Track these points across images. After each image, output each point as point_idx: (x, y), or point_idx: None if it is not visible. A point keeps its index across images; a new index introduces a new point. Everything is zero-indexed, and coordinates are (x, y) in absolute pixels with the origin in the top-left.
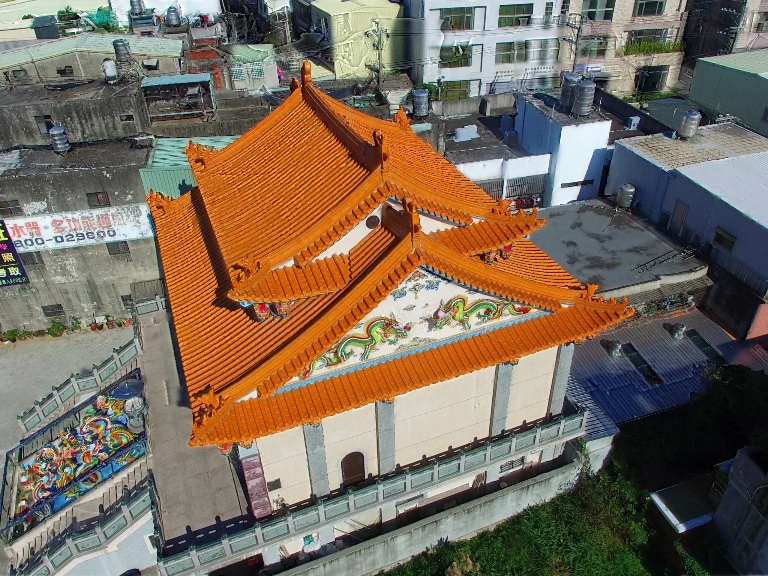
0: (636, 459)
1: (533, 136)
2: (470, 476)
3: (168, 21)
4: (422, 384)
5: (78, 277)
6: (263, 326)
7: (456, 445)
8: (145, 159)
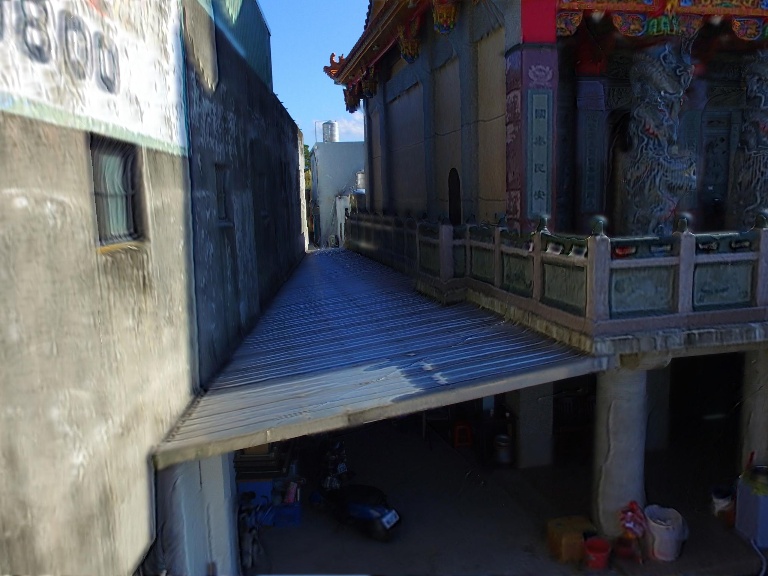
0: None
1: None
2: None
3: None
4: None
5: None
6: None
7: None
8: None
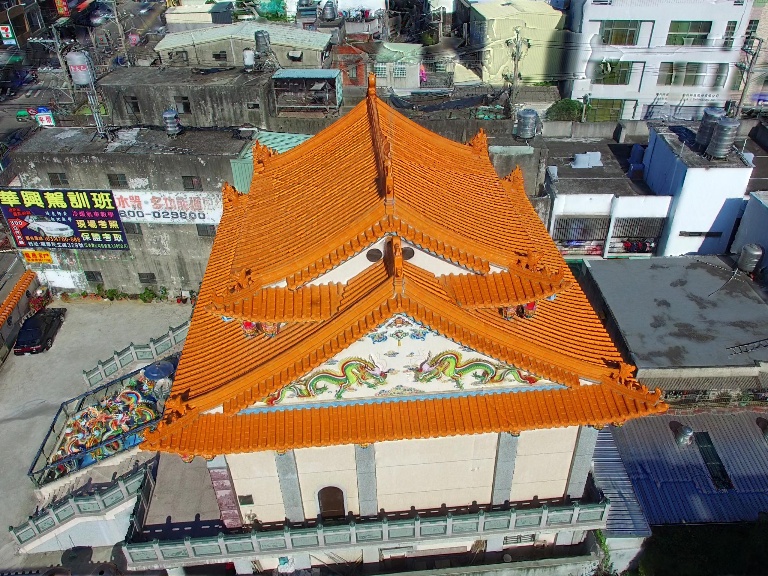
0: (668, 572)
1: (658, 173)
2: (459, 541)
3: (323, 15)
4: (393, 437)
5: (170, 251)
6: (254, 341)
7: (451, 504)
8: (239, 150)
